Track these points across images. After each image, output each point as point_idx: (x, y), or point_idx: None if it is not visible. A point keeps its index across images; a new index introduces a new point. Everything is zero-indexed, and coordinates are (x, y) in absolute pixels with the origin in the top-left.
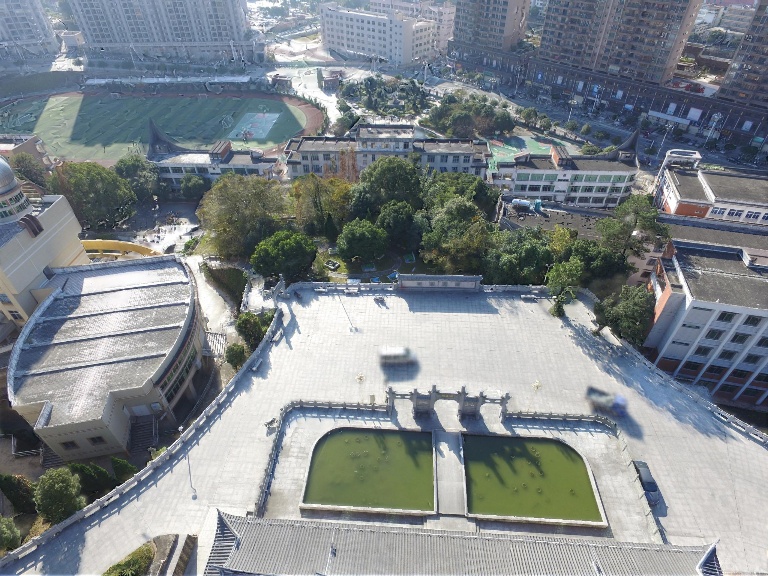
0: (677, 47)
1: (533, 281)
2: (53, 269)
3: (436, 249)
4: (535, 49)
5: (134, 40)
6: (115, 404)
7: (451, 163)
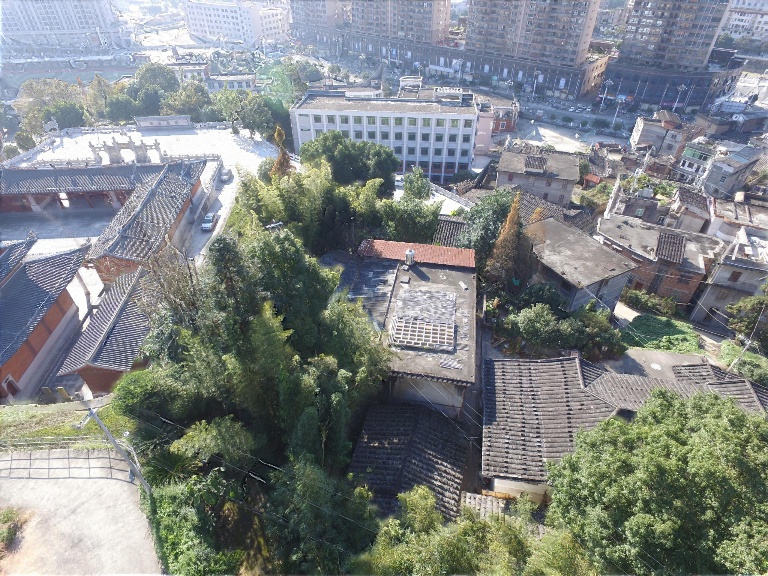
0: (437, 14)
1: None
2: None
3: (168, 107)
4: (351, 25)
5: (4, 29)
6: None
7: (237, 88)
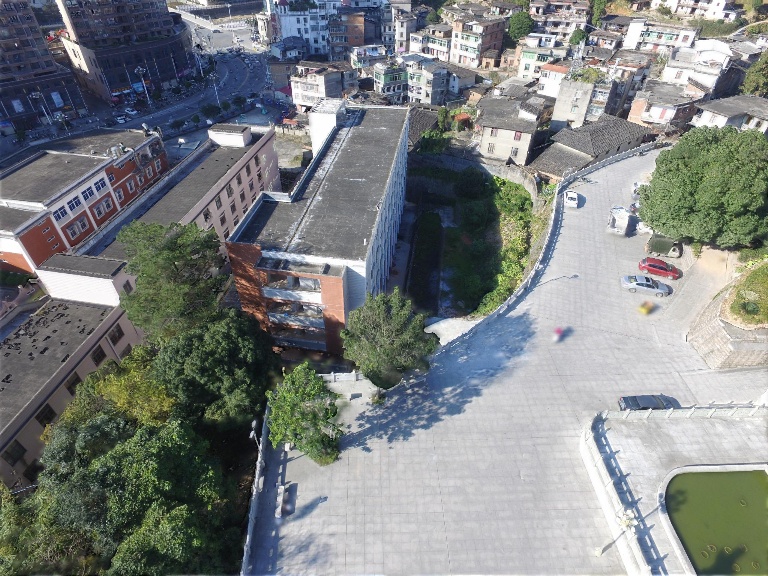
0: None
1: (231, 481)
2: None
3: None
4: None
5: None
6: None
7: None
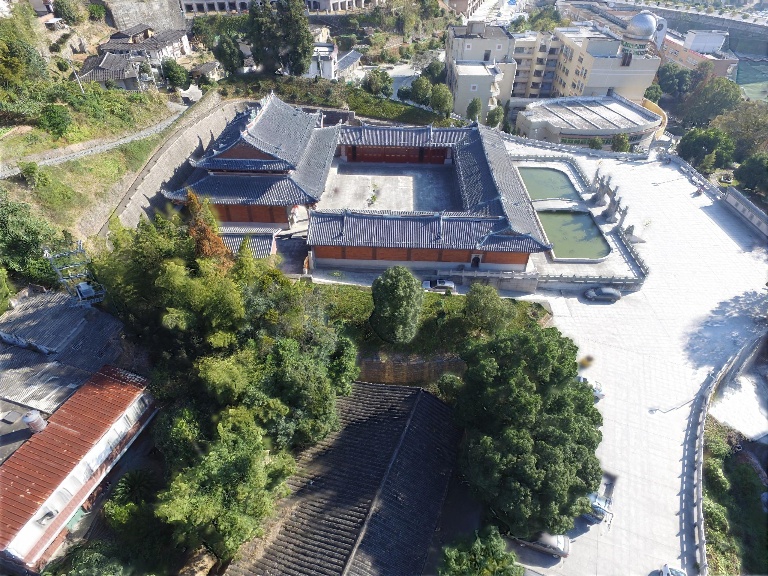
0: None
1: None
2: (614, 93)
3: None
4: None
5: None
6: (544, 129)
7: None
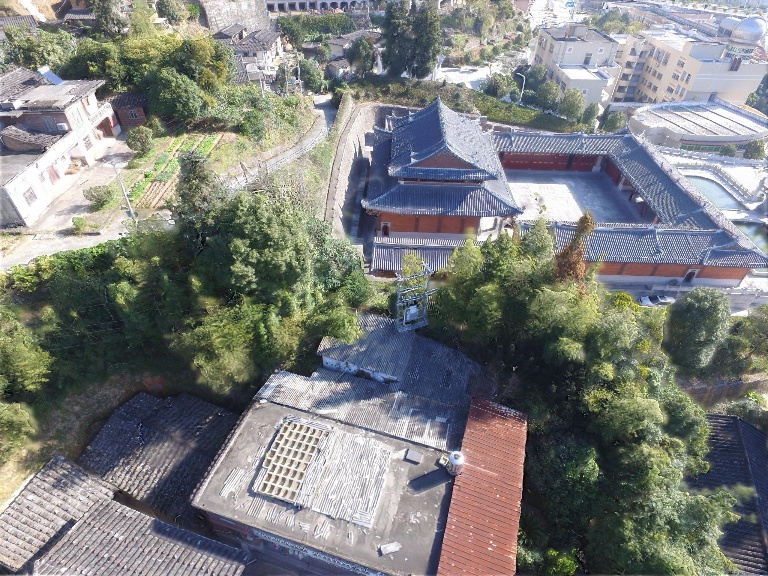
0: None
1: None
2: (716, 98)
3: None
4: None
5: None
6: (660, 135)
7: None
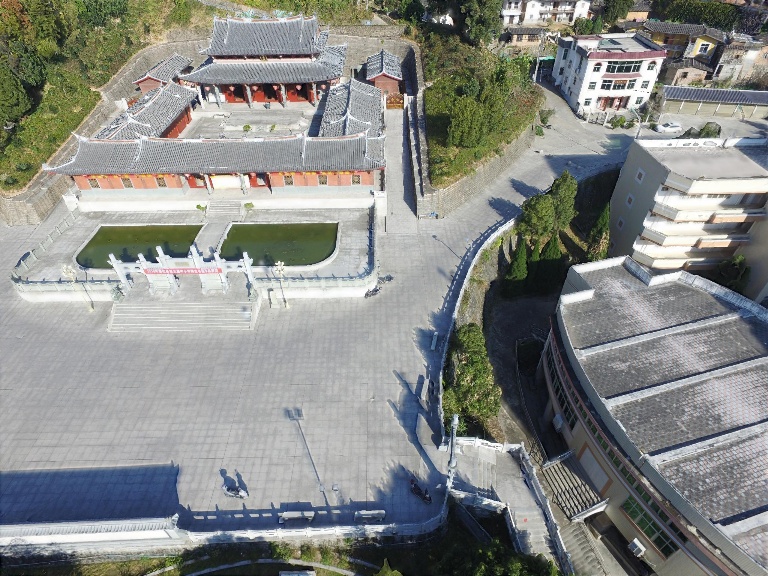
0: None
1: None
2: None
3: None
4: None
5: None
6: None
7: None
